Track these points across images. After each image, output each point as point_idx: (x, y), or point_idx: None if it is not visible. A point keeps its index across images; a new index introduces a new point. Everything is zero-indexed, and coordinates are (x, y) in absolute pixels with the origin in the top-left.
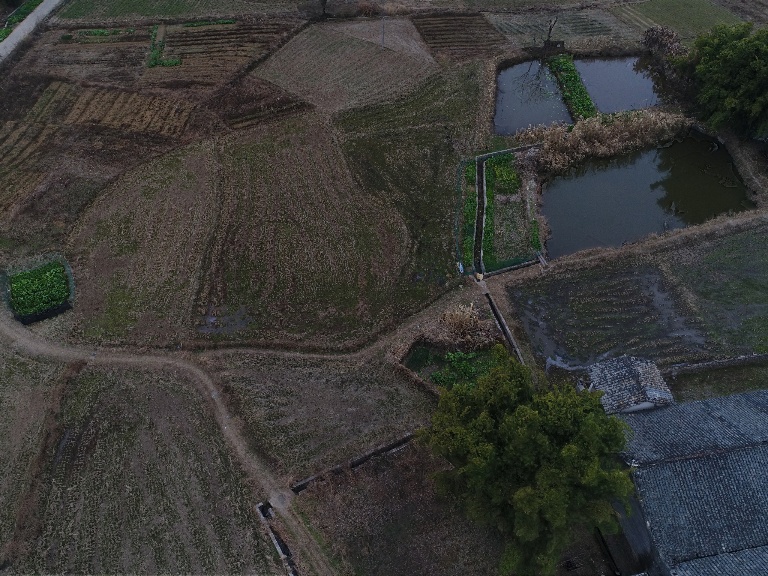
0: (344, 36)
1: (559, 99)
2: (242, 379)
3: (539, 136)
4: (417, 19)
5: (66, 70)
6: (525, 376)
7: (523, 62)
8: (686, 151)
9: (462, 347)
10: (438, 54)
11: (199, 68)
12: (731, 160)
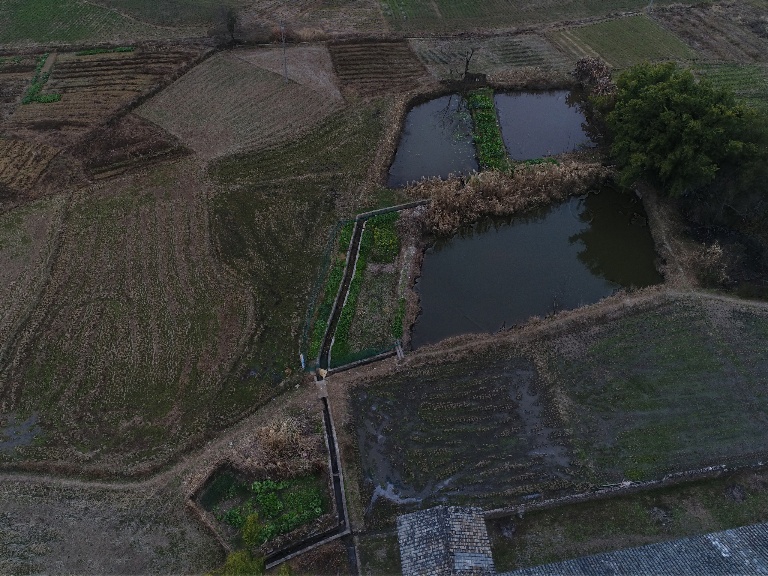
0: (249, 66)
1: (468, 142)
2: (2, 517)
3: None
4: (334, 46)
5: None
6: None
7: (440, 97)
8: (607, 201)
9: (273, 474)
10: (346, 88)
11: (78, 105)
12: (646, 219)
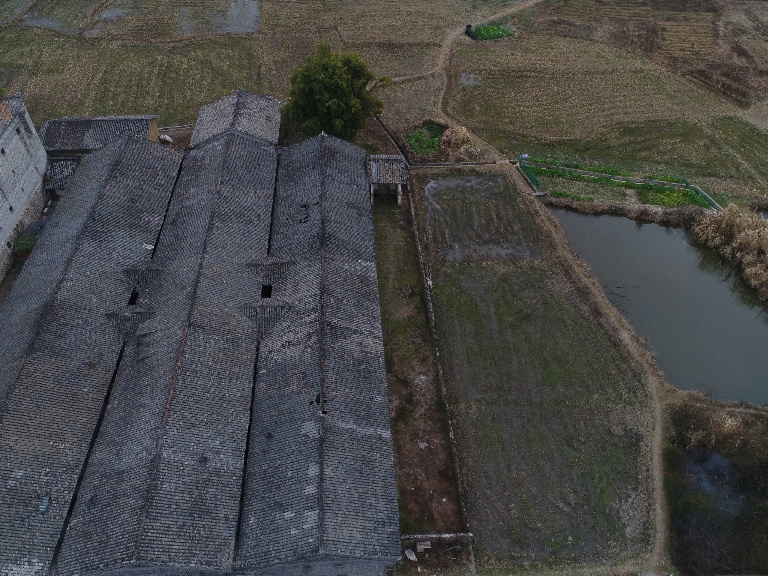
0: None
1: None
2: None
3: (759, 230)
4: None
5: (734, 14)
6: (355, 62)
7: None
8: None
9: None
10: None
11: None
12: None
